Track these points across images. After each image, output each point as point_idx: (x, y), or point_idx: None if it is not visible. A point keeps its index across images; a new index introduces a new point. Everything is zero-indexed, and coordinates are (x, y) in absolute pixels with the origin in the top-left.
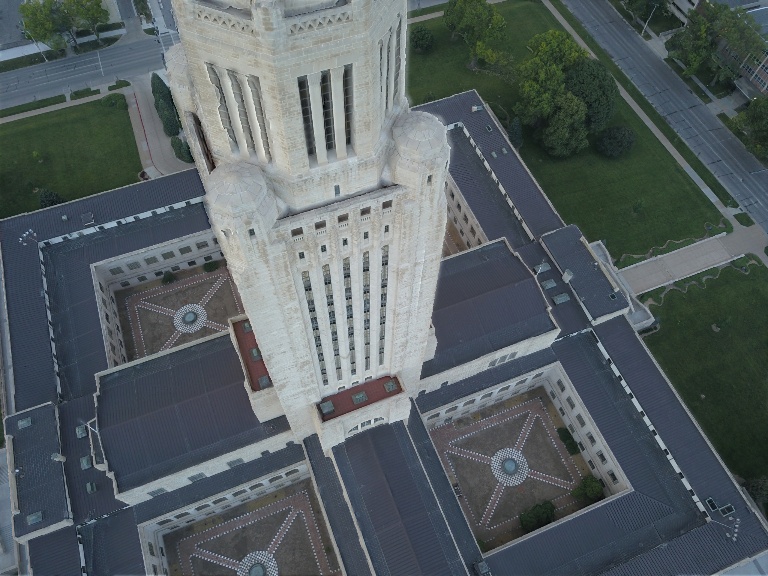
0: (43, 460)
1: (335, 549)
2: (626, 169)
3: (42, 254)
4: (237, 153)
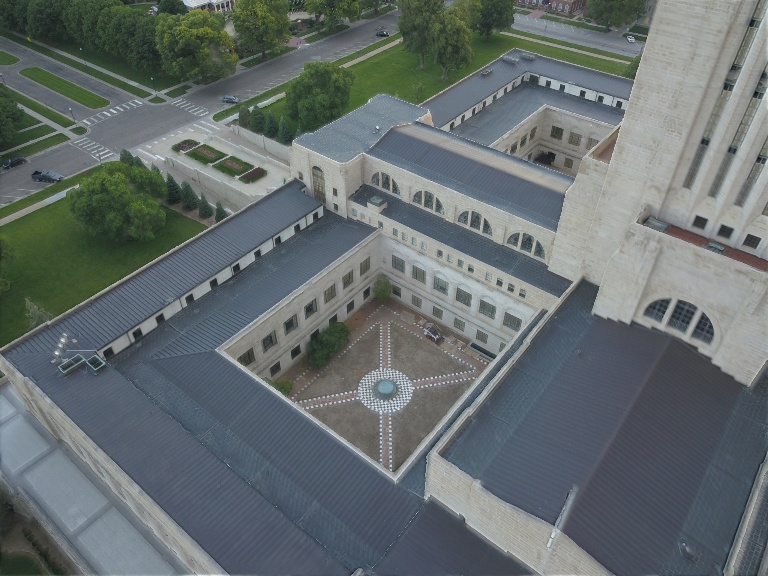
0: None
1: None
2: None
3: None
4: None
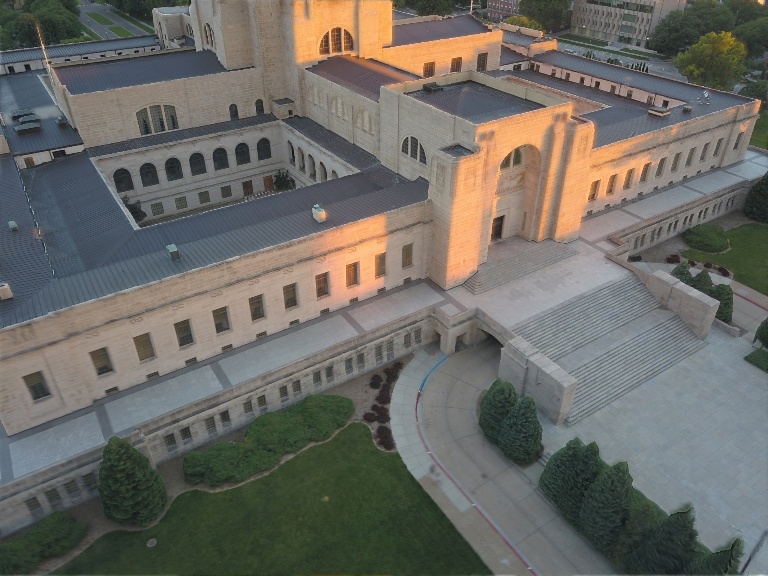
0: None
1: None
2: None
3: None
4: None
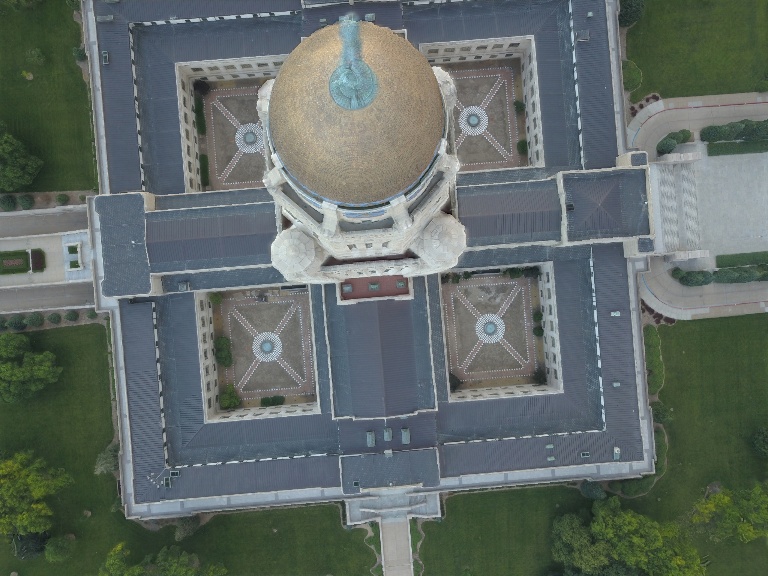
0: None
1: None
2: None
3: None
4: None
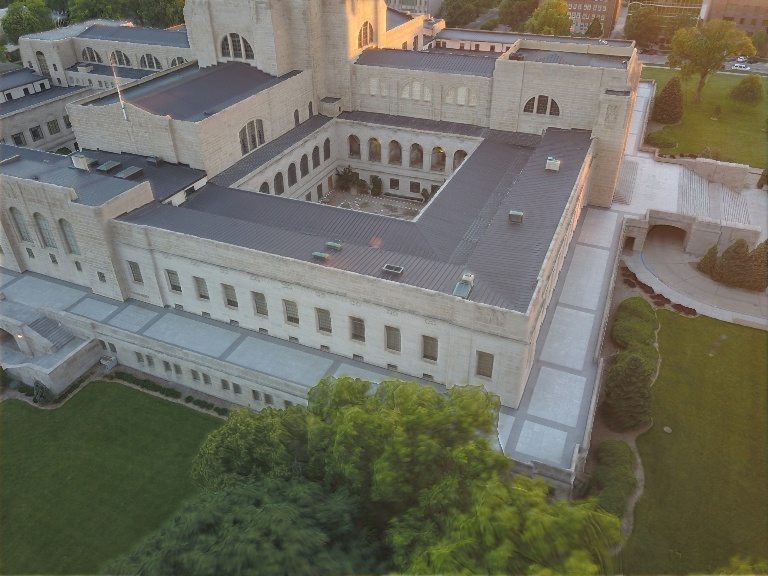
0: None
1: None
2: None
3: None
4: None
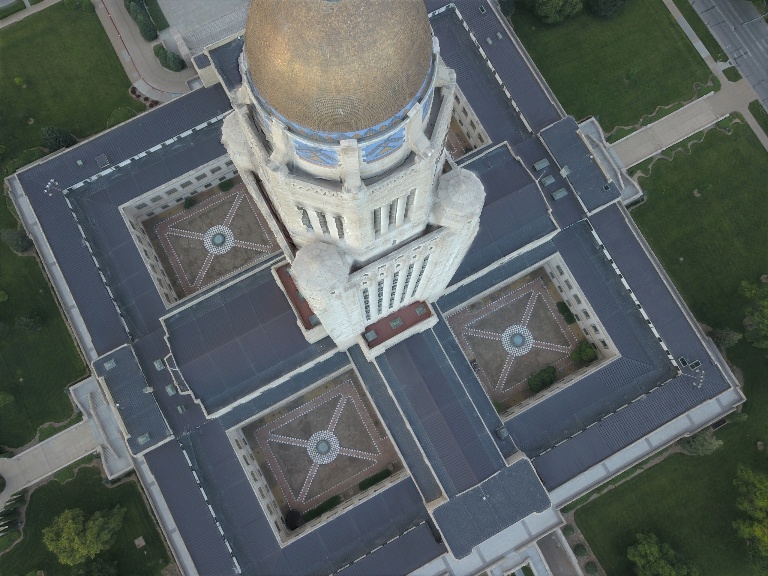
0: (135, 393)
1: (386, 430)
2: (619, 29)
3: (68, 201)
4: (312, 232)
